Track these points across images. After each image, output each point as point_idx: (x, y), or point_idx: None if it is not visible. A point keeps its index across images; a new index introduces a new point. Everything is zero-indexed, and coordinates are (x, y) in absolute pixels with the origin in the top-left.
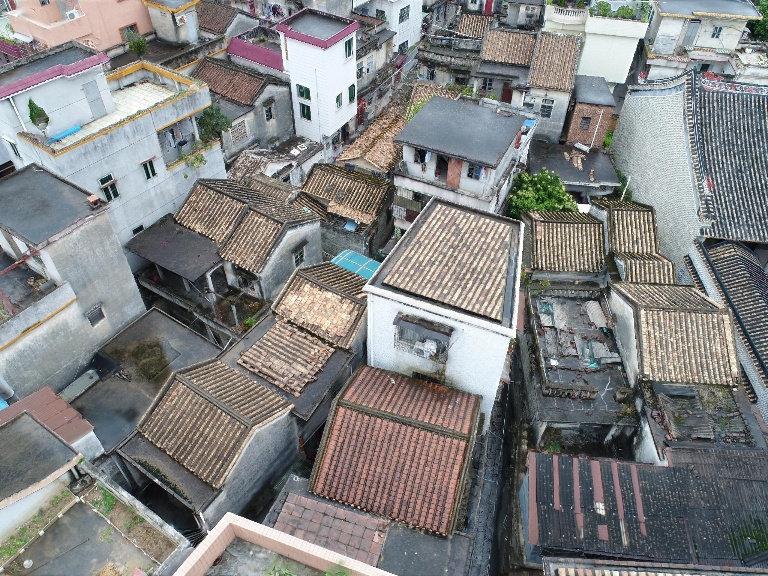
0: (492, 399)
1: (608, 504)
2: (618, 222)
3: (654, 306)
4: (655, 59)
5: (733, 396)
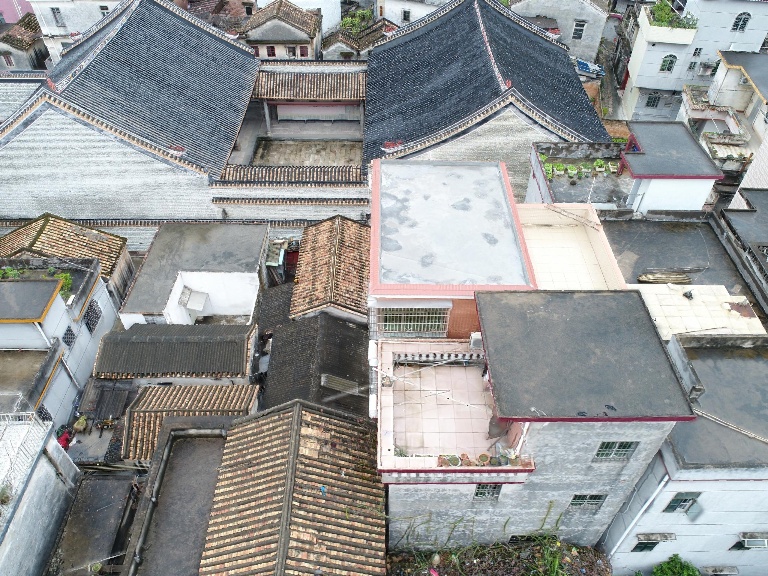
0: (258, 5)
1: (200, 9)
2: (377, 32)
3: (280, 1)
4: (685, 93)
5: (239, 32)
